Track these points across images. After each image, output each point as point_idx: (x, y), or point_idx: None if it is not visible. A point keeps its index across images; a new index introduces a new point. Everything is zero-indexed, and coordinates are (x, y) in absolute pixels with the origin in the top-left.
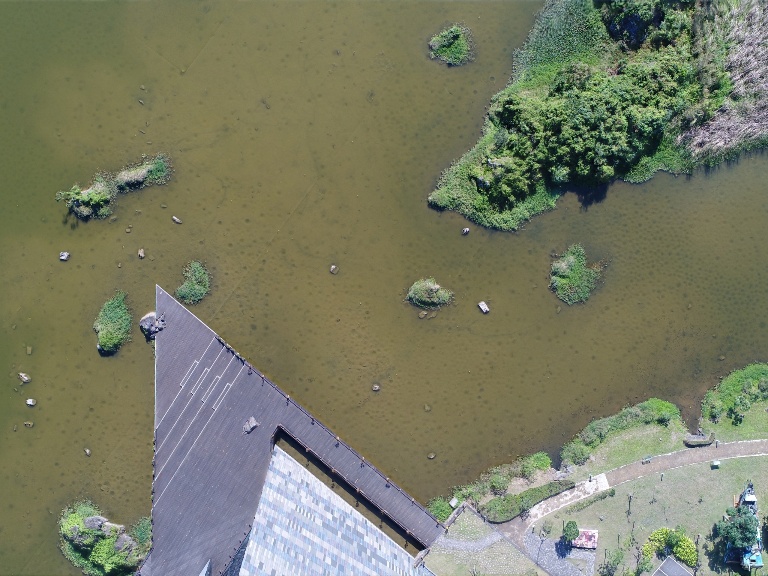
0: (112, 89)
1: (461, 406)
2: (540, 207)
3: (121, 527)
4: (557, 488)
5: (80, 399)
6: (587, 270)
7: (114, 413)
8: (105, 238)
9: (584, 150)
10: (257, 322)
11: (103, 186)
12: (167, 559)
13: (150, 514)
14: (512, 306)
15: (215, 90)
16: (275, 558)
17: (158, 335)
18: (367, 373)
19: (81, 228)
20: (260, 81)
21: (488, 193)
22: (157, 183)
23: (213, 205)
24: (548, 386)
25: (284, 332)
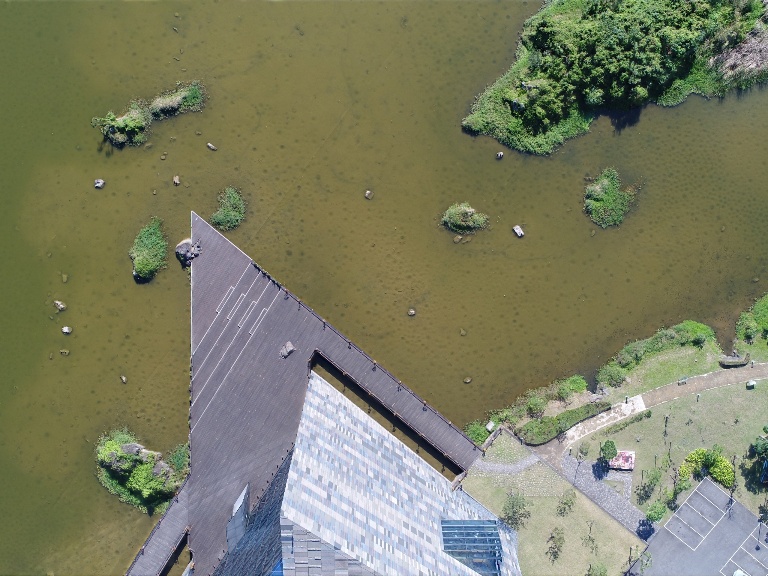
0: (146, 17)
1: (497, 330)
2: (574, 131)
3: (158, 454)
4: (594, 410)
5: (116, 326)
6: (621, 193)
7: (150, 340)
8: (140, 165)
9: (618, 71)
10: (292, 248)
11: (138, 113)
12: (205, 485)
13: (187, 441)
14: (547, 230)
15: (249, 17)
16: (321, 466)
17: (194, 261)
18: (403, 298)
19: (116, 156)
20: (294, 8)
21: (522, 116)
22: (192, 110)
23: (248, 132)
24: (583, 309)
25: (319, 258)
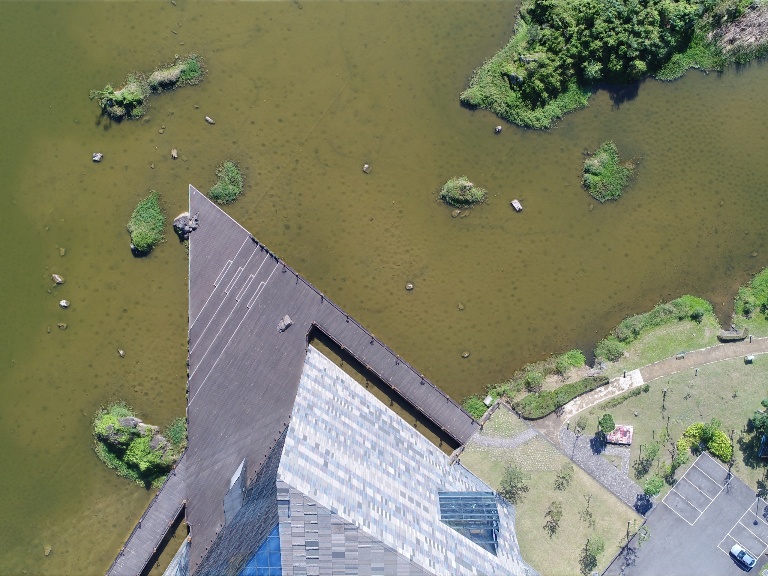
0: None
1: (495, 304)
2: (572, 105)
3: (155, 428)
4: (592, 384)
5: (114, 300)
6: (619, 167)
7: (148, 314)
8: (138, 139)
9: (617, 44)
10: (290, 222)
11: (136, 86)
12: (202, 458)
13: (184, 415)
14: (545, 204)
15: None
16: (318, 434)
17: (192, 235)
18: (401, 272)
19: (114, 129)
20: None
21: (521, 89)
22: (190, 83)
23: (246, 105)
24: (581, 284)
25: (317, 232)
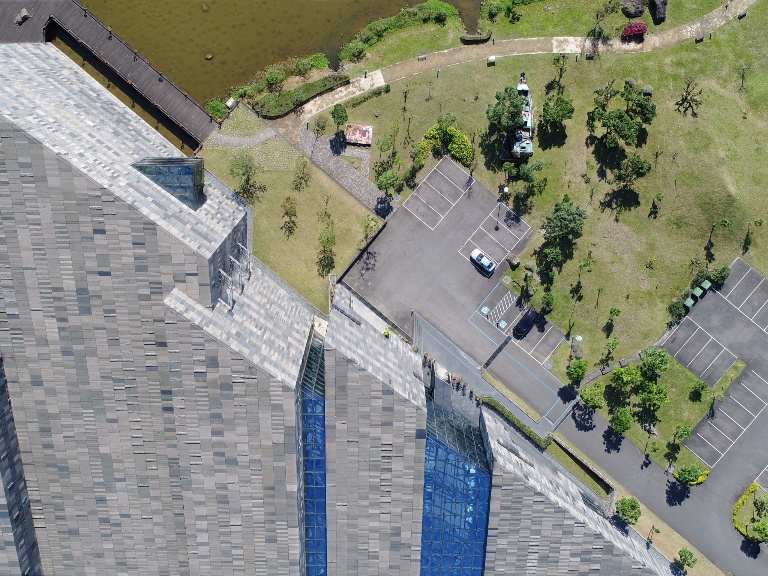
0: None
1: (239, 6)
2: None
3: None
4: (331, 82)
5: None
6: None
7: None
8: None
9: None
10: None
11: None
12: None
13: None
14: None
15: None
16: None
17: None
18: None
19: None
20: None
21: None
22: None
23: None
24: None
25: None
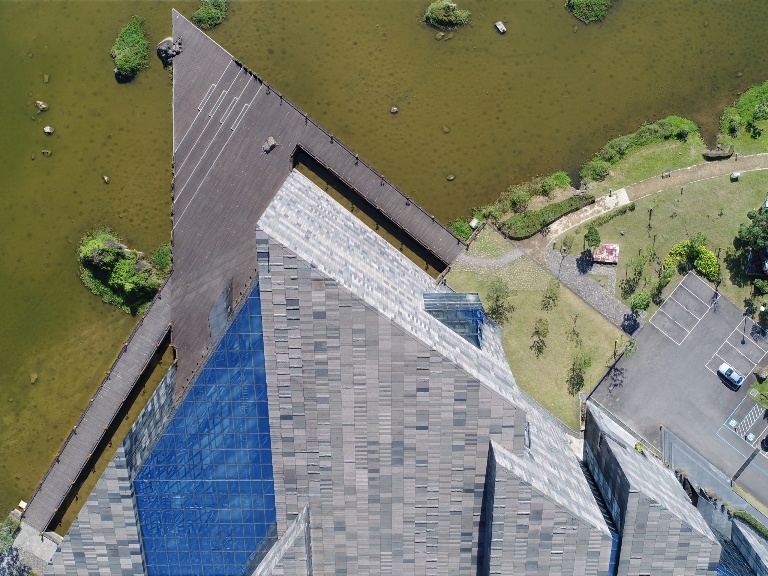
0: None
1: (480, 127)
2: None
3: (141, 253)
4: (577, 202)
5: (98, 127)
6: None
7: (132, 140)
8: None
9: None
10: (274, 46)
11: None
12: (187, 281)
13: (169, 241)
14: (529, 26)
15: None
16: (300, 219)
17: (175, 59)
18: (385, 96)
19: None
20: None
21: None
22: None
23: None
24: (566, 106)
25: (301, 56)
